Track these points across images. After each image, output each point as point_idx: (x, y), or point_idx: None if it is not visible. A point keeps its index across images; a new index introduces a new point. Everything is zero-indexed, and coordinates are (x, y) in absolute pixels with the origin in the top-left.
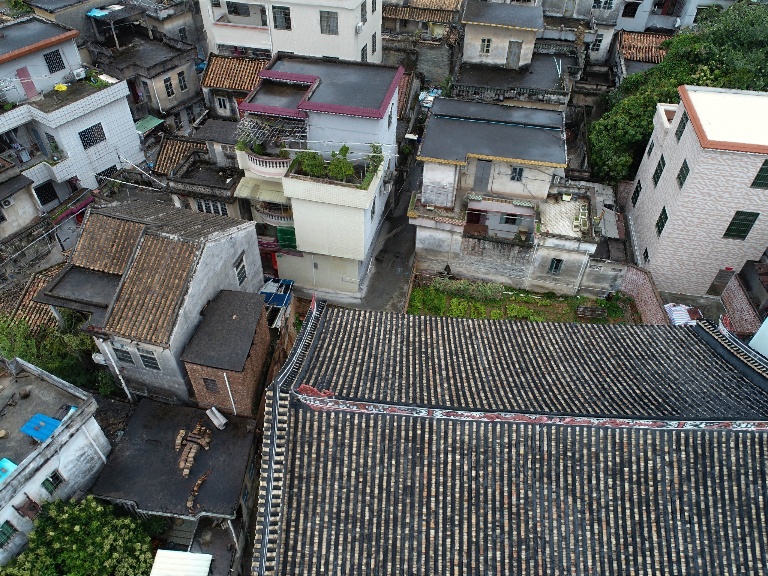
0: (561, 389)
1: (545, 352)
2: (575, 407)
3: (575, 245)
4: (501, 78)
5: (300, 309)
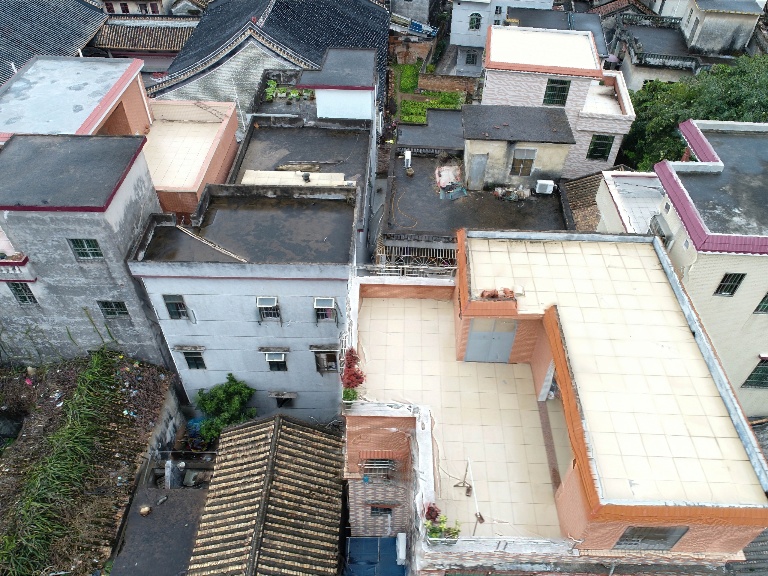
0: None
1: None
2: None
3: None
4: (664, 42)
5: (431, 56)
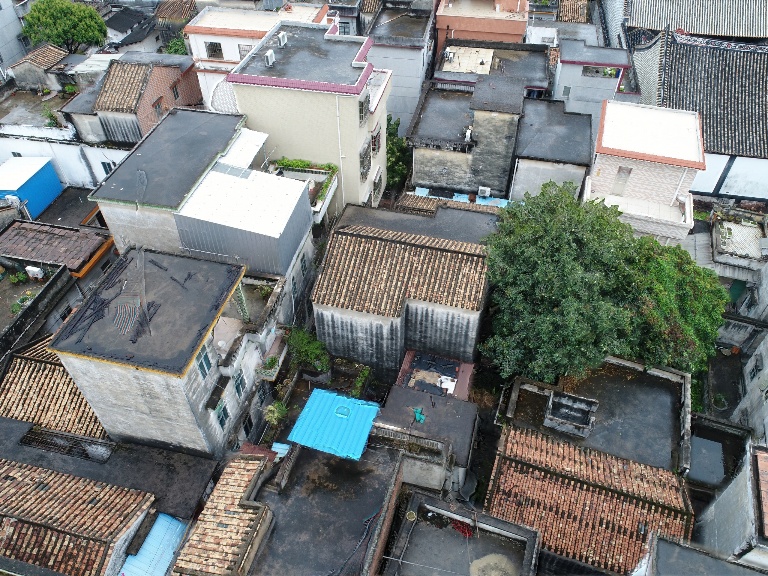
0: (764, 86)
1: (763, 122)
2: (765, 67)
3: (731, 213)
4: None
5: None
